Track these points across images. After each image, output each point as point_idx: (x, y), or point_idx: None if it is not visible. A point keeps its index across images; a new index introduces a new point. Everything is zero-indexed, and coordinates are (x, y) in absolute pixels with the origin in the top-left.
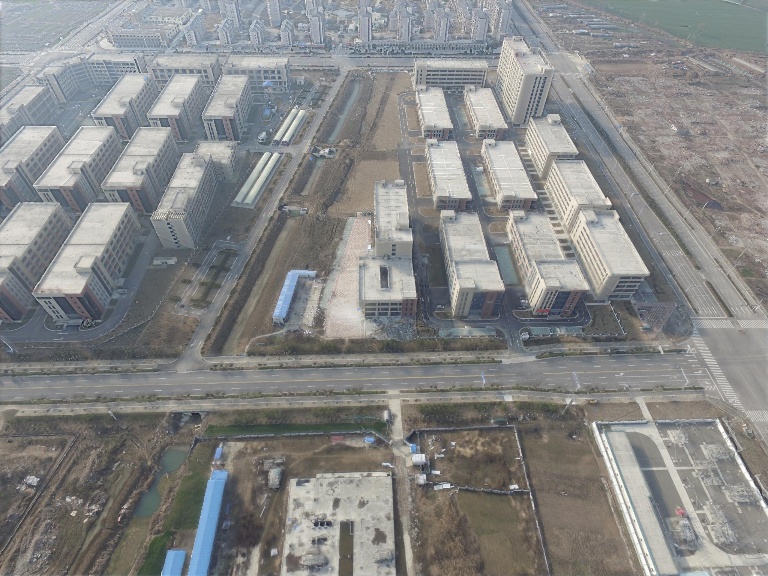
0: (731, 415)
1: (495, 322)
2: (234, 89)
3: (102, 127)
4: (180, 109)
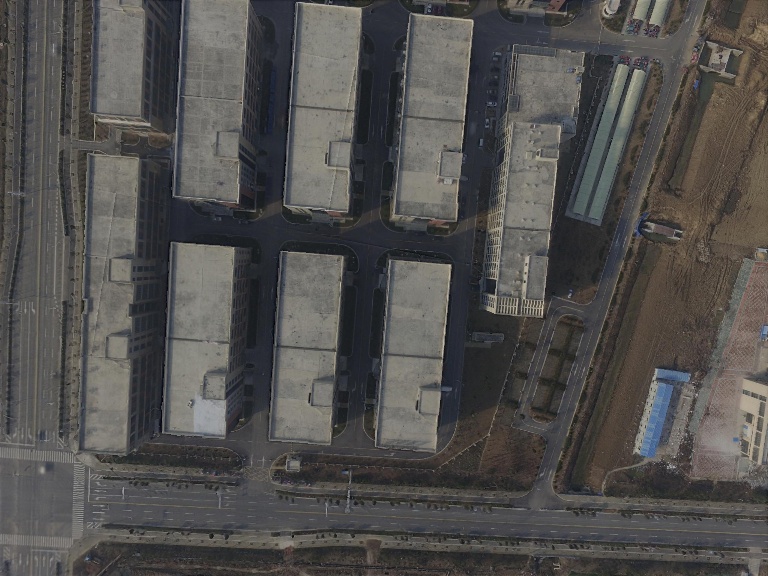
0: None
1: None
2: None
3: (338, 7)
4: None
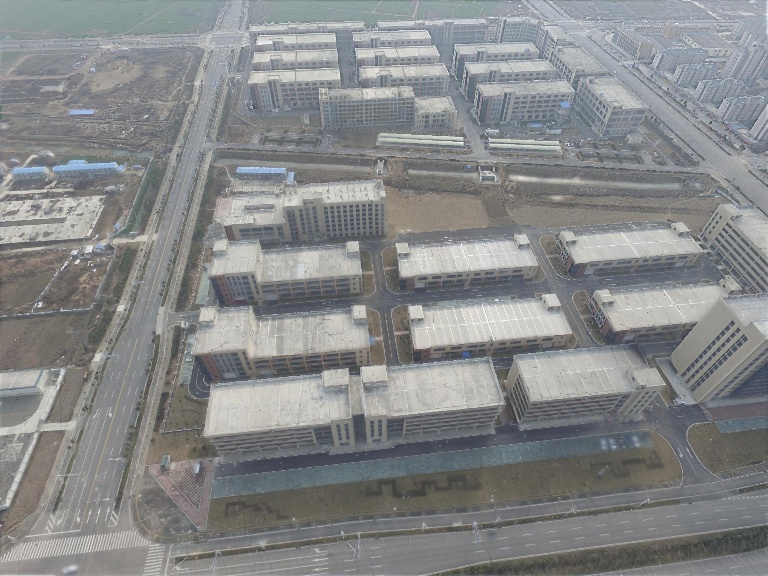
0: (4, 535)
1: (213, 304)
2: (540, 90)
3: None
4: (483, 73)
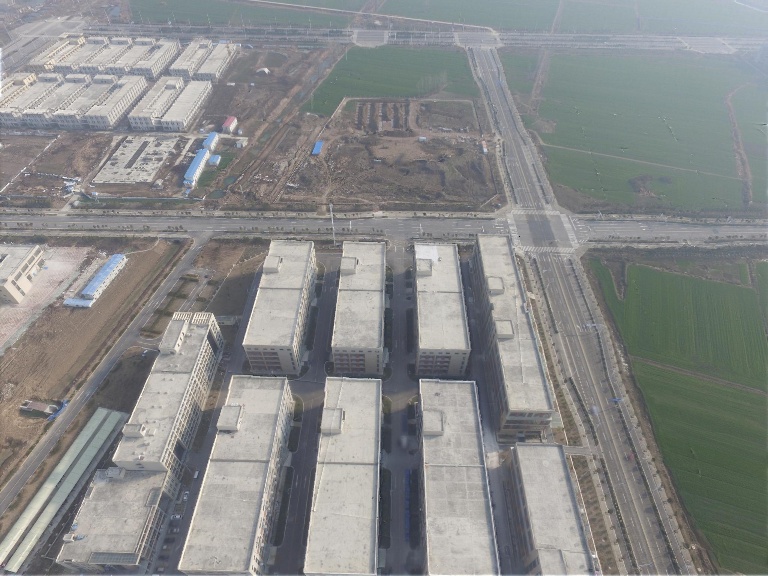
0: None
1: None
2: None
3: (330, 573)
4: None
